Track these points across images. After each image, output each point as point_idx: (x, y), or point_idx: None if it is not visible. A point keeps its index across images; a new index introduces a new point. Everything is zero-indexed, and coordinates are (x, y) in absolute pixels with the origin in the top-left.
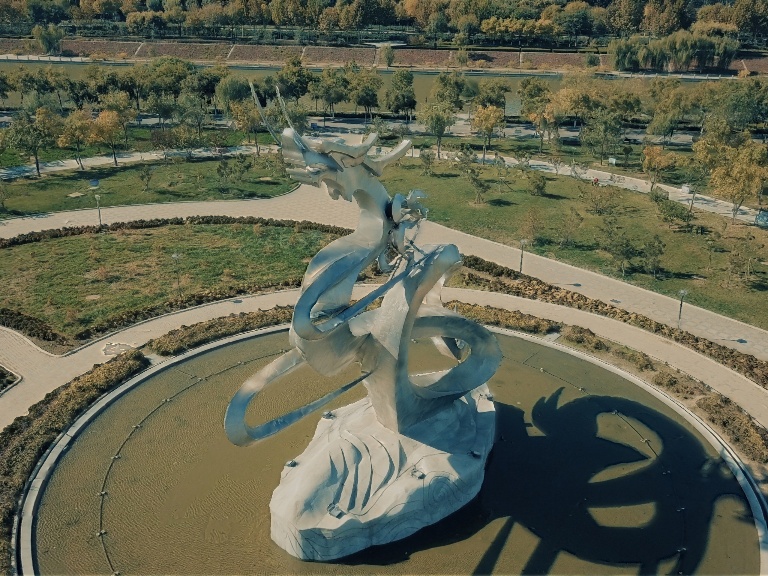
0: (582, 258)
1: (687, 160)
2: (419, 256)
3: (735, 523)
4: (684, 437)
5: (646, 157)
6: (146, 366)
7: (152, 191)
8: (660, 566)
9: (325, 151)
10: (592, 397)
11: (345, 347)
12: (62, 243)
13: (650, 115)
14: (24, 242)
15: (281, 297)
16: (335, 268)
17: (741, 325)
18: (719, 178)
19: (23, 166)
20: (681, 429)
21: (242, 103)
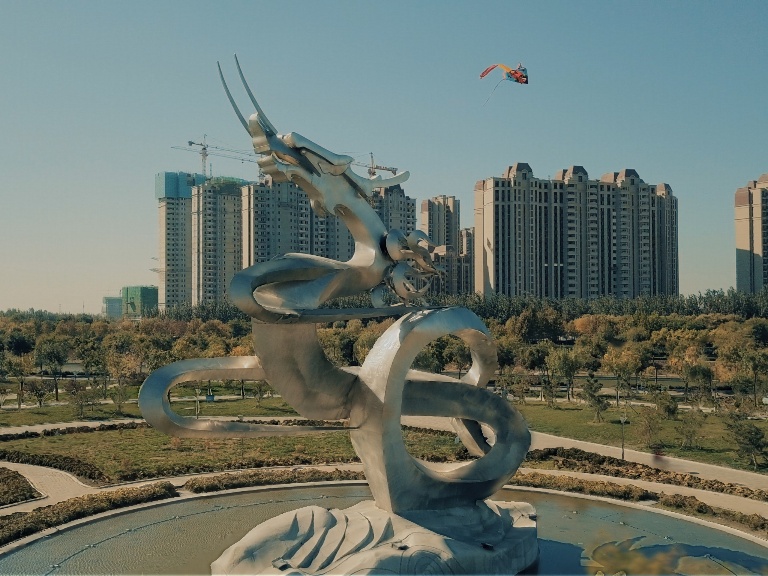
0: (707, 457)
1: None
2: None
3: None
4: None
5: None
6: (173, 497)
7: (263, 408)
8: None
9: (296, 144)
10: (680, 544)
11: (318, 375)
12: None
13: None
14: None
15: (346, 467)
16: (298, 262)
17: None
18: None
19: None
20: None
21: None
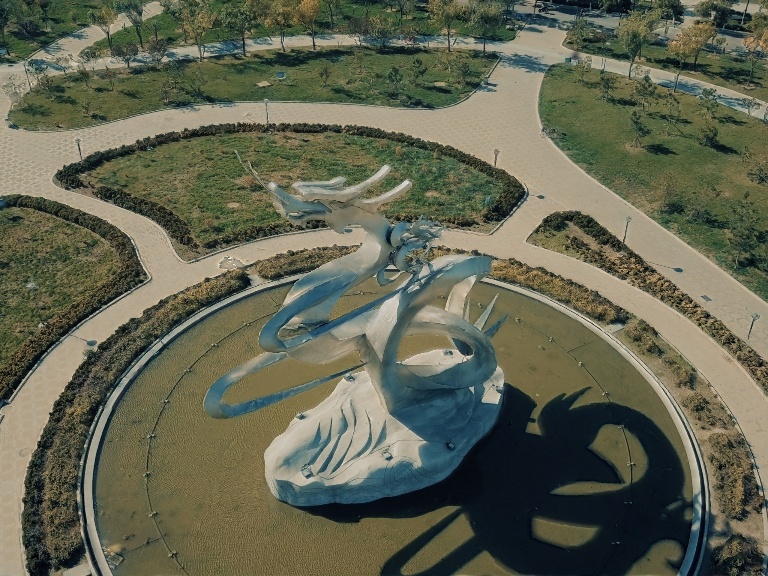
0: (704, 237)
1: None
2: (425, 272)
3: (658, 570)
4: (672, 470)
5: None
6: (246, 286)
7: (329, 88)
8: None
9: (309, 200)
10: (610, 405)
11: (333, 346)
12: (232, 140)
13: None
14: (202, 134)
15: None
16: (313, 293)
17: None
18: None
19: (236, 41)
20: (675, 460)
21: None
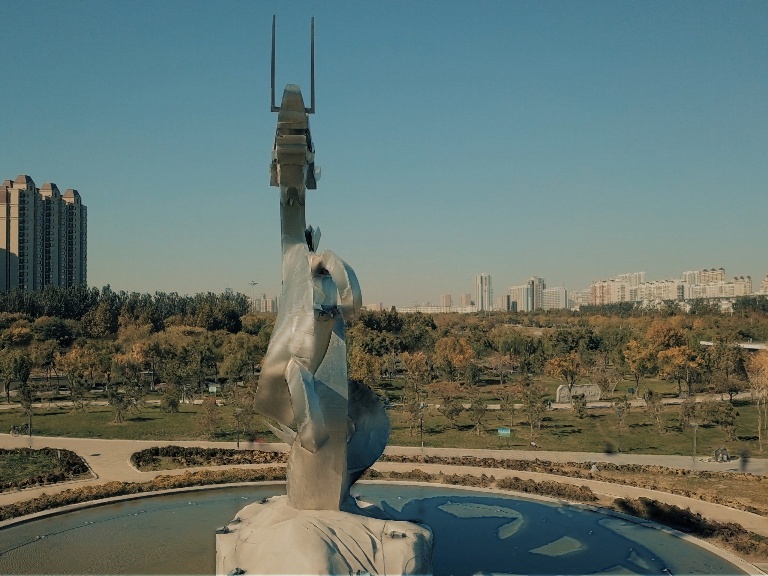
0: (273, 438)
1: None
2: None
3: (633, 530)
4: (520, 503)
5: None
6: None
7: None
8: (634, 562)
9: None
10: (416, 500)
11: None
12: None
13: (216, 360)
14: None
15: None
16: None
17: (455, 450)
18: None
19: None
20: (511, 500)
21: None
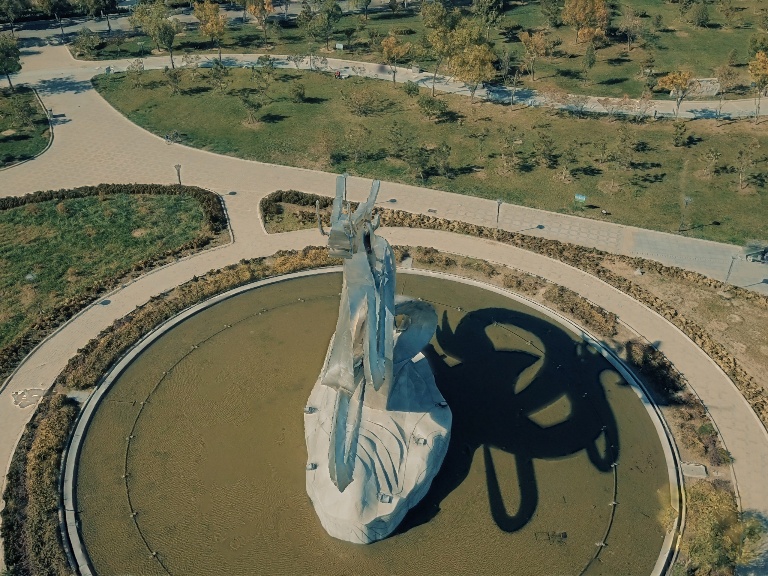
0: (380, 169)
1: (424, 50)
2: (378, 264)
3: (621, 393)
4: (552, 331)
5: (385, 49)
6: (77, 407)
7: None
8: (598, 446)
9: None
10: (472, 314)
11: None
12: None
13: None
14: None
15: (145, 285)
16: (370, 319)
17: (532, 211)
18: (458, 66)
19: None
20: (546, 324)
21: None
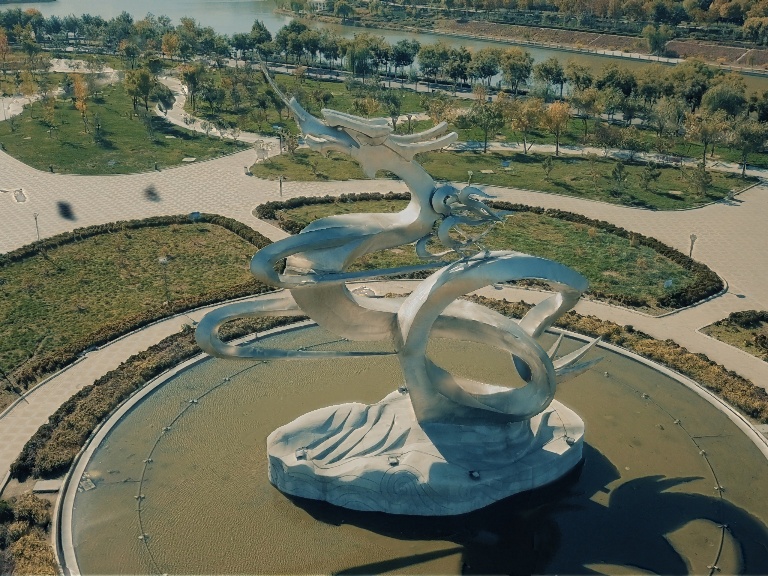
0: None
1: None
2: (478, 257)
3: None
4: None
5: None
6: None
7: (551, 181)
8: None
9: (330, 124)
10: (720, 501)
11: (354, 314)
12: None
13: None
14: (404, 198)
15: (539, 296)
16: (324, 233)
17: None
18: None
19: (484, 142)
20: None
21: (713, 113)
